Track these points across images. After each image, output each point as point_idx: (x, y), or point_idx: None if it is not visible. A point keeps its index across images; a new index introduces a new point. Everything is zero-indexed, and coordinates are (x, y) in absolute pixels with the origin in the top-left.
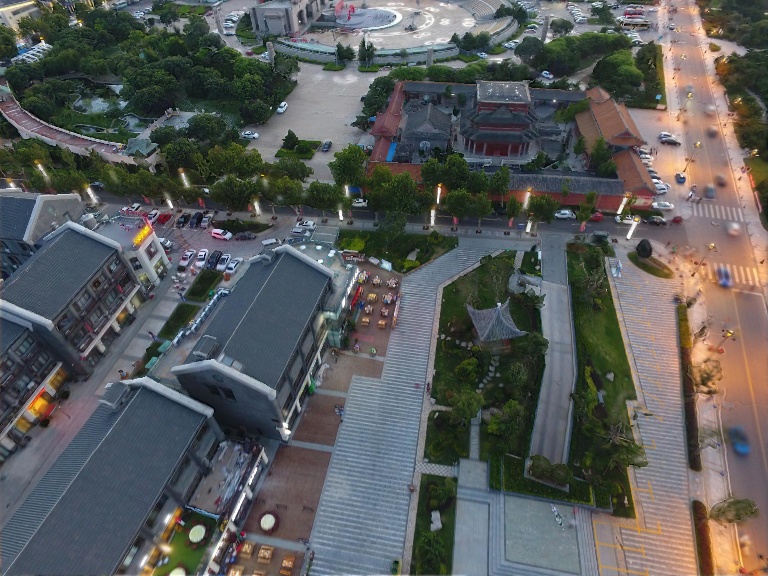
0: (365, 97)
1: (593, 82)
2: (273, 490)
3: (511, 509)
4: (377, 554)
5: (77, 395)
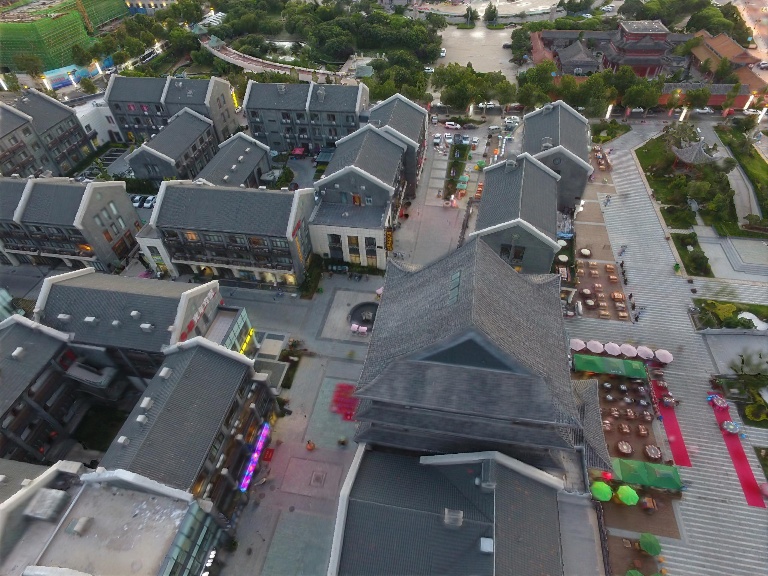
0: (507, 44)
1: (694, 29)
2: (578, 241)
3: (737, 244)
4: (661, 264)
5: (413, 205)
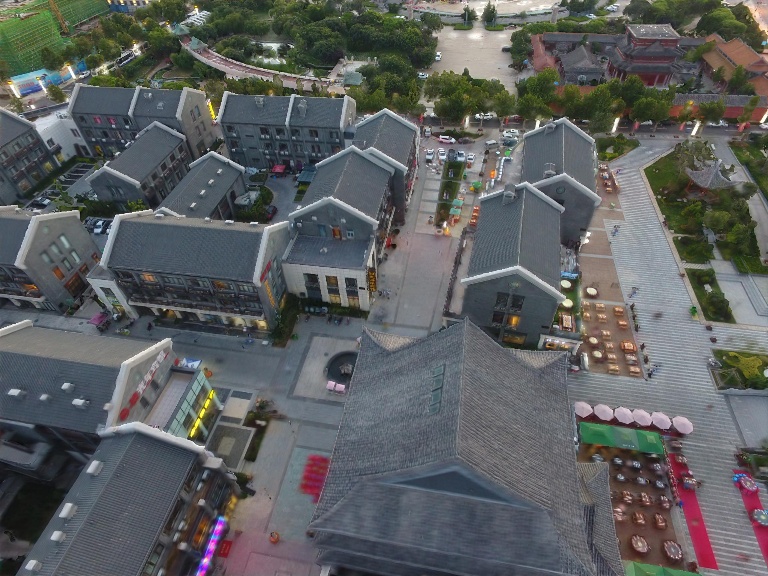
0: (506, 48)
1: (704, 32)
2: (583, 278)
3: (760, 282)
4: (676, 306)
5: (402, 233)
